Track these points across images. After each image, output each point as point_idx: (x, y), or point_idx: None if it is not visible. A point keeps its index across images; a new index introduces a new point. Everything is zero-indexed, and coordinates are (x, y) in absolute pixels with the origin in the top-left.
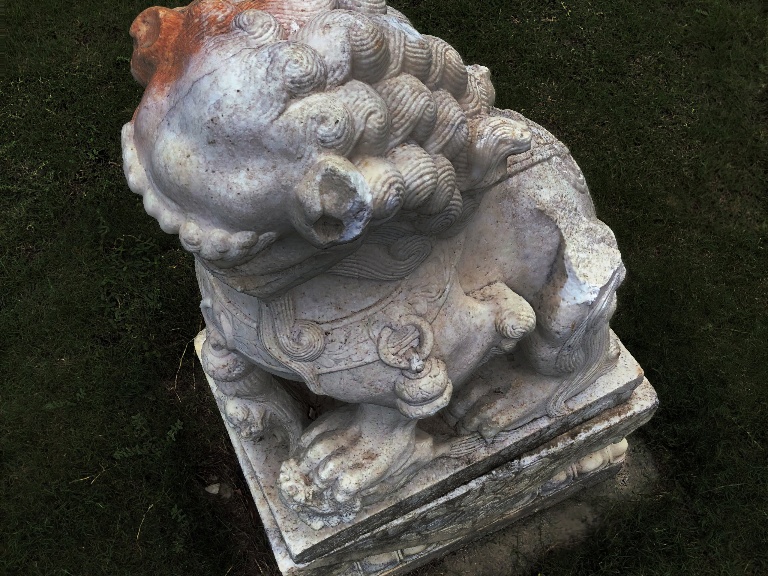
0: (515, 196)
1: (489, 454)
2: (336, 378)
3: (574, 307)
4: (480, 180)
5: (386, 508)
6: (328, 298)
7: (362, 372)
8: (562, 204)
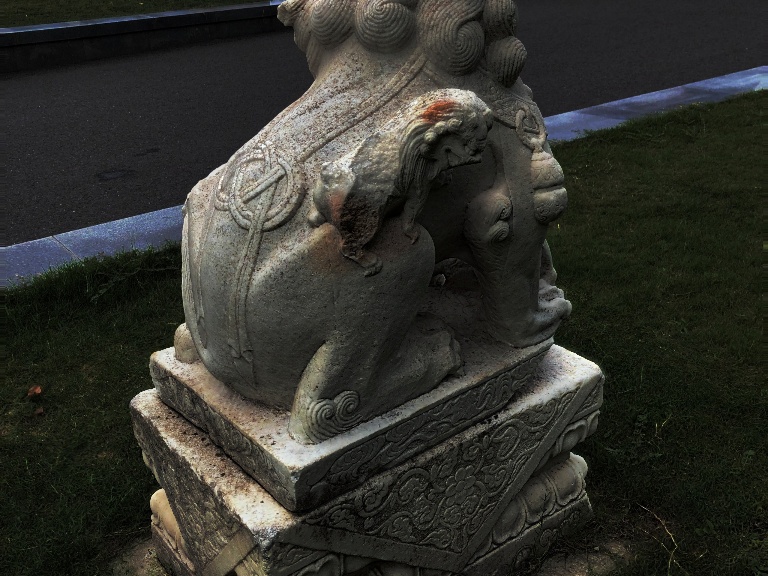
0: None
1: None
2: None
3: None
4: None
5: None
6: None
7: None
8: None
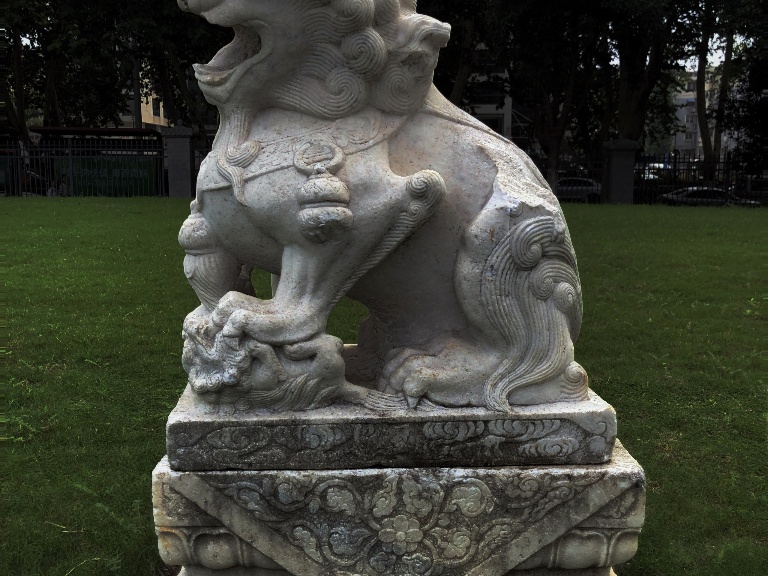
0: (460, 134)
1: (407, 415)
2: (257, 184)
3: (493, 212)
4: (404, 45)
5: (278, 420)
6: (275, 127)
7: (277, 177)
8: (506, 159)
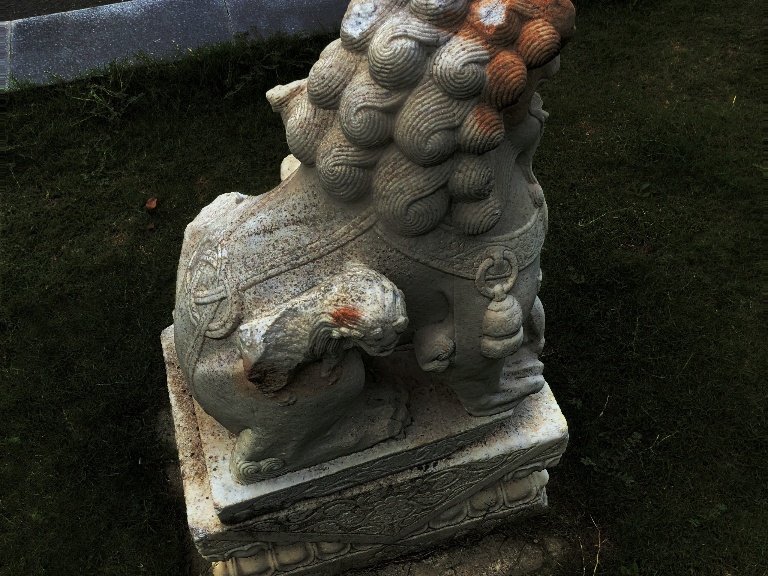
0: None
1: None
2: None
3: None
4: None
5: None
6: None
7: None
8: None
